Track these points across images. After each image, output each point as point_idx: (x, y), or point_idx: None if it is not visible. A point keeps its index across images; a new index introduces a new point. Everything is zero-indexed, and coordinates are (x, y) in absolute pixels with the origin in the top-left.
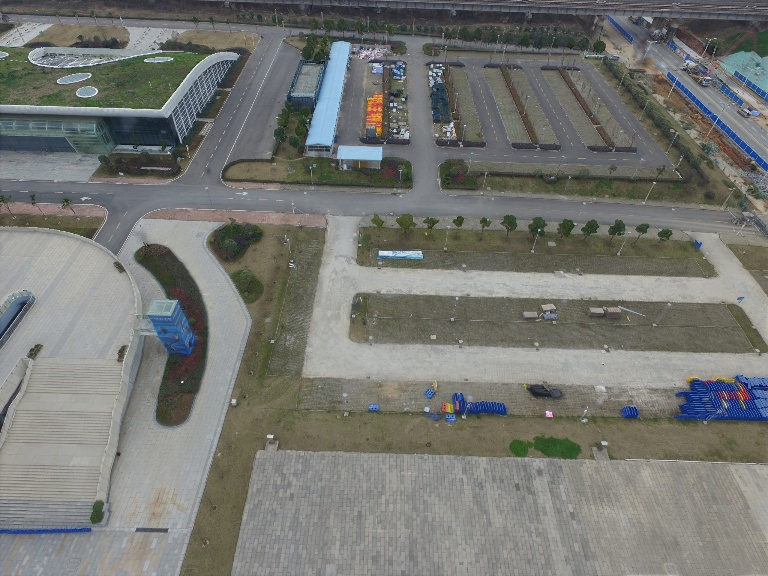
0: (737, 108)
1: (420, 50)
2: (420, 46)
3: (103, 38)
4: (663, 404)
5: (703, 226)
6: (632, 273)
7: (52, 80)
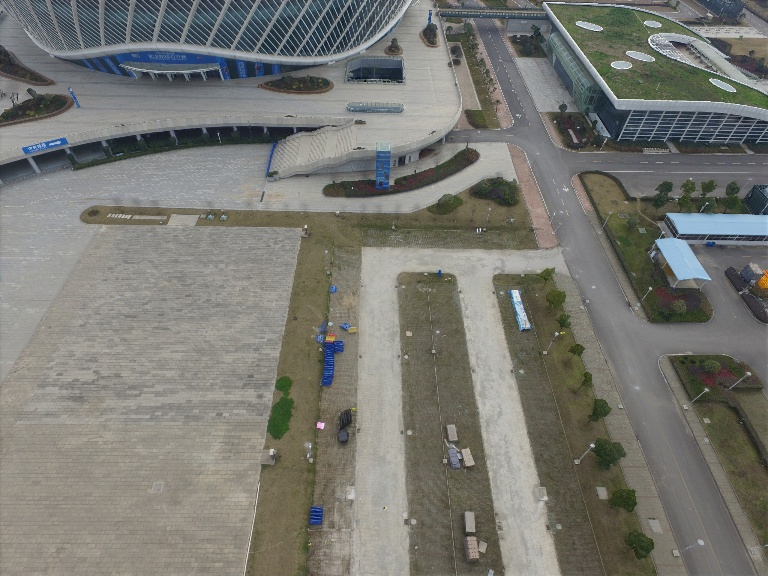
0: None
1: None
2: None
3: None
4: (327, 571)
5: None
6: None
7: (629, 49)
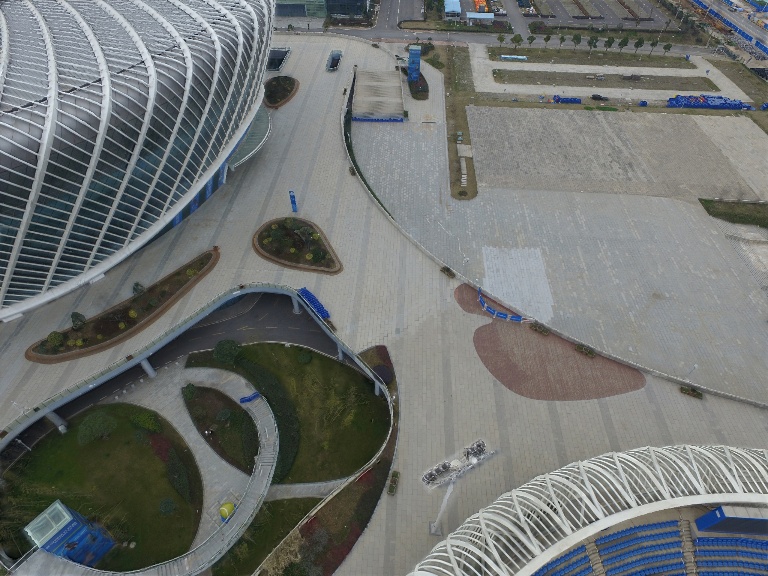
0: (728, 8)
1: None
2: None
3: None
4: (660, 104)
5: (693, 53)
6: (647, 66)
7: None
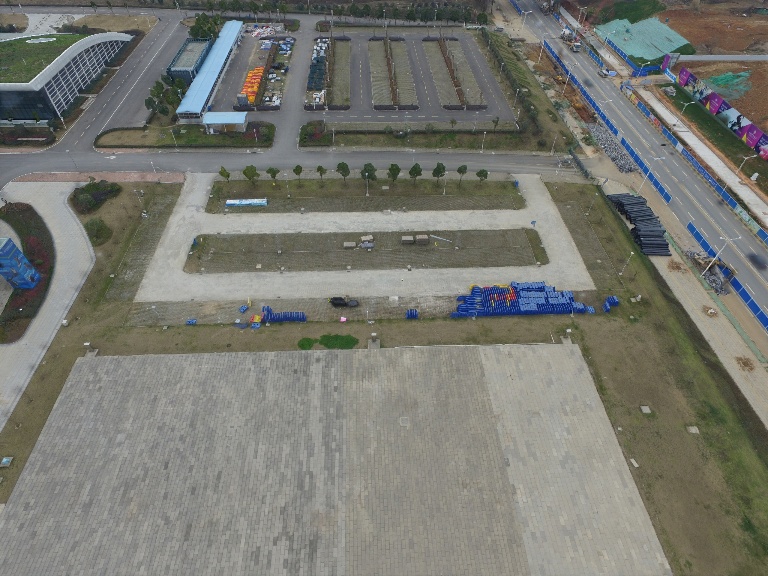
0: (599, 70)
1: (313, 27)
2: (314, 23)
3: (1, 25)
4: (444, 307)
5: (529, 169)
6: (451, 208)
7: None
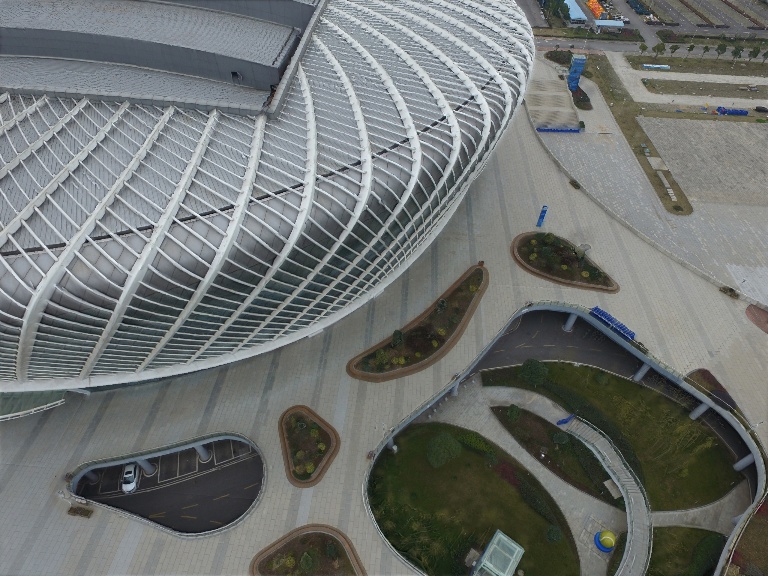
0: None
1: None
2: None
3: None
4: None
5: None
6: None
7: None
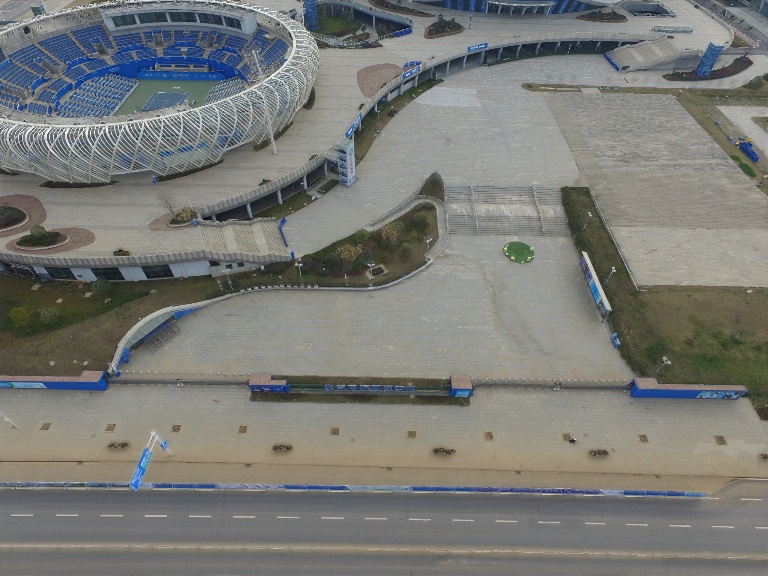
0: None
1: None
2: None
3: None
4: None
5: None
6: None
7: None
